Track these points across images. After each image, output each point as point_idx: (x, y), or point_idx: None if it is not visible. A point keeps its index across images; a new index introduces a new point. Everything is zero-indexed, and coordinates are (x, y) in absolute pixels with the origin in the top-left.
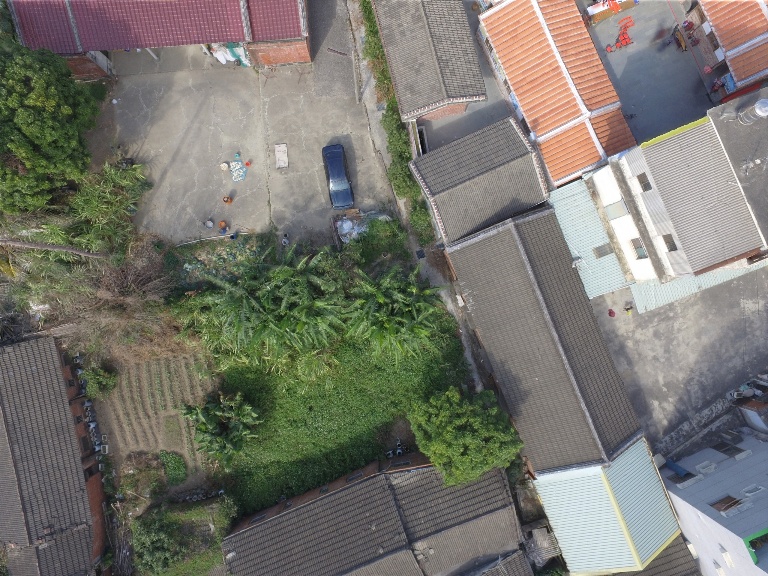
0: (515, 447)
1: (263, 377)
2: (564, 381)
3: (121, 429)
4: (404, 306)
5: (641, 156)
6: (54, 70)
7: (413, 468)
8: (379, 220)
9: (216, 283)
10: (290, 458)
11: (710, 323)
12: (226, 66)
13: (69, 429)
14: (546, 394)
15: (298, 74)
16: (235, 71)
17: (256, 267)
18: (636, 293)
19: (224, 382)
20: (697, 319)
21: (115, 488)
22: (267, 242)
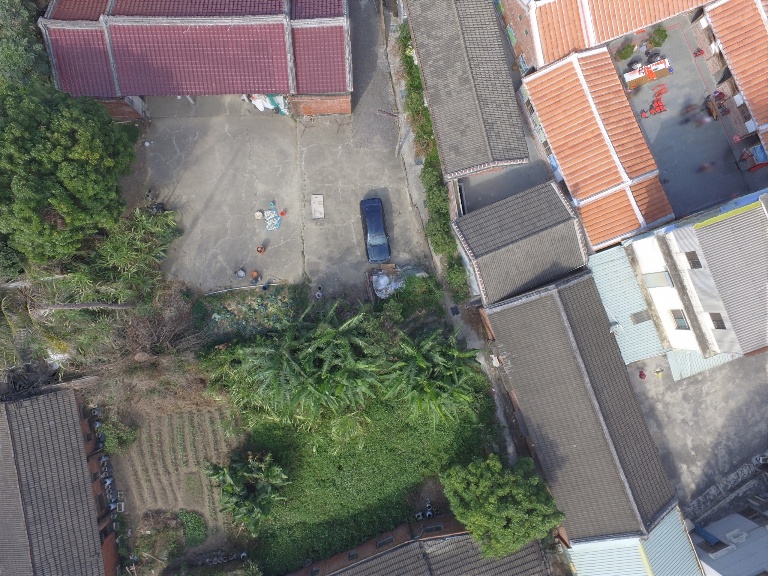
0: (557, 520)
1: (291, 434)
2: (603, 450)
3: (139, 486)
4: (445, 370)
5: (692, 235)
6: (97, 120)
7: (448, 535)
8: (416, 277)
9: (245, 334)
10: (317, 519)
11: (737, 387)
12: (264, 113)
13: (86, 488)
14: (584, 462)
15: (337, 125)
16: (273, 119)
17: (295, 325)
18: (672, 360)
19: (250, 438)
20: (725, 383)
21: (130, 549)
22: (300, 294)
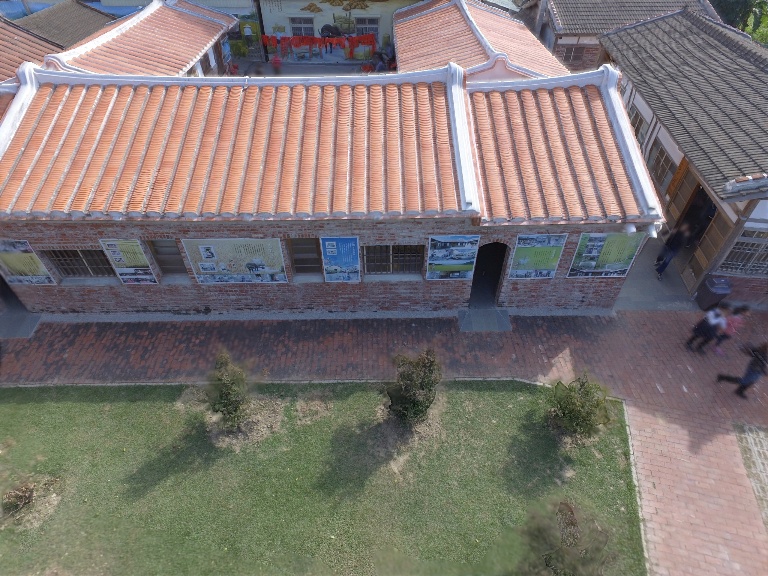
0: None
1: None
2: None
3: None
4: None
5: None
6: None
7: None
8: None
9: None
10: None
11: None
12: None
13: None
14: None
15: None
16: None
17: None
18: None
19: None
20: None
21: None
22: None
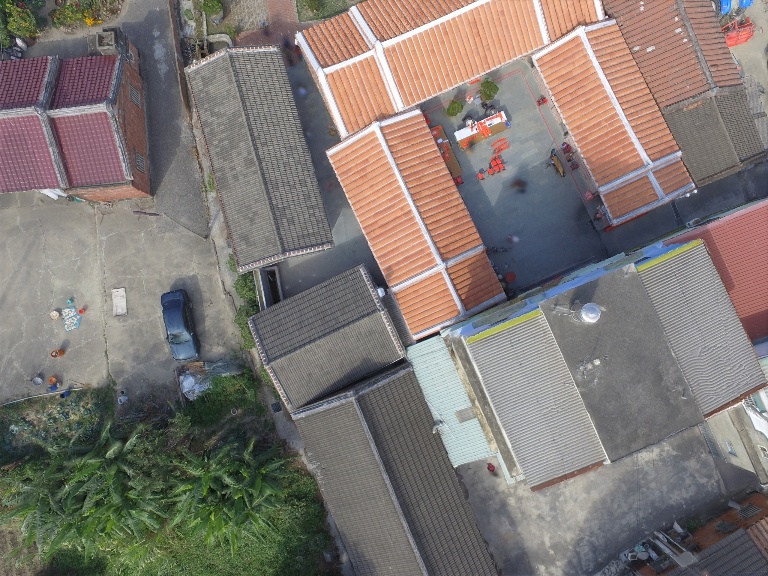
0: None
1: (98, 554)
2: (418, 574)
3: None
4: (234, 493)
5: None
6: None
7: None
8: (223, 377)
9: (46, 446)
10: None
11: (600, 476)
12: (58, 202)
13: None
14: None
15: (138, 209)
16: (68, 207)
17: (66, 451)
18: None
19: (53, 561)
20: None
21: None
22: (103, 399)
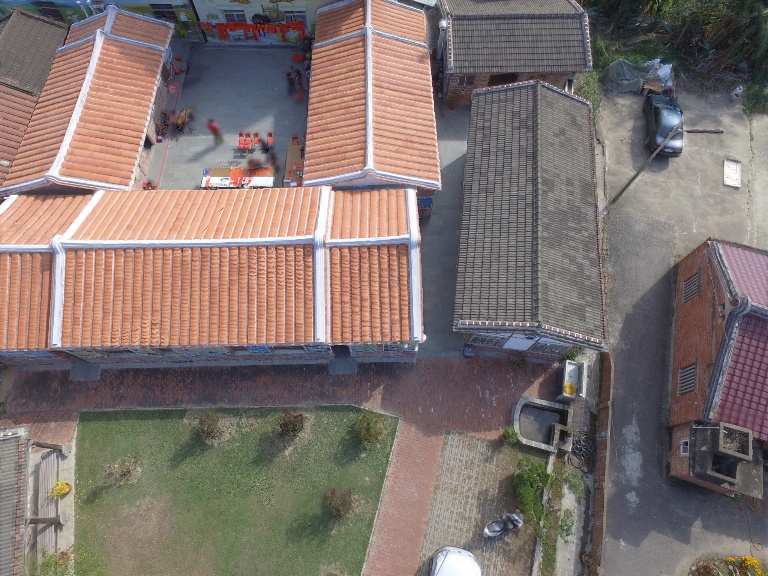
0: None
1: None
2: None
3: None
4: None
5: None
6: None
7: None
8: None
9: None
10: None
11: None
12: None
13: None
14: None
15: None
16: None
17: None
18: None
19: None
20: None
21: None
22: (758, 102)
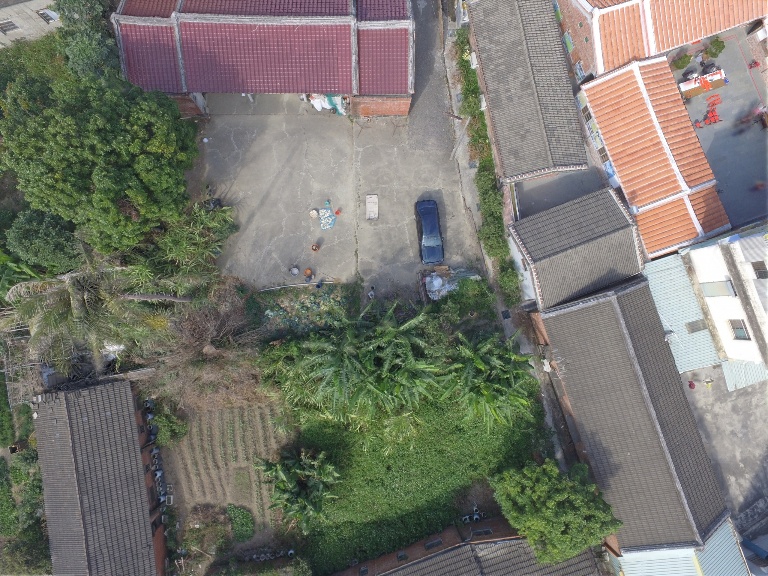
0: (614, 527)
1: (341, 432)
2: (658, 458)
3: (188, 479)
4: (502, 373)
5: (761, 245)
6: (171, 115)
7: (499, 540)
8: (470, 279)
9: (297, 332)
10: (364, 519)
11: None
12: (321, 113)
13: (139, 480)
14: (638, 470)
15: (393, 126)
16: (330, 119)
17: (353, 324)
18: (727, 371)
19: (300, 435)
20: None
21: (177, 542)
22: (352, 293)
